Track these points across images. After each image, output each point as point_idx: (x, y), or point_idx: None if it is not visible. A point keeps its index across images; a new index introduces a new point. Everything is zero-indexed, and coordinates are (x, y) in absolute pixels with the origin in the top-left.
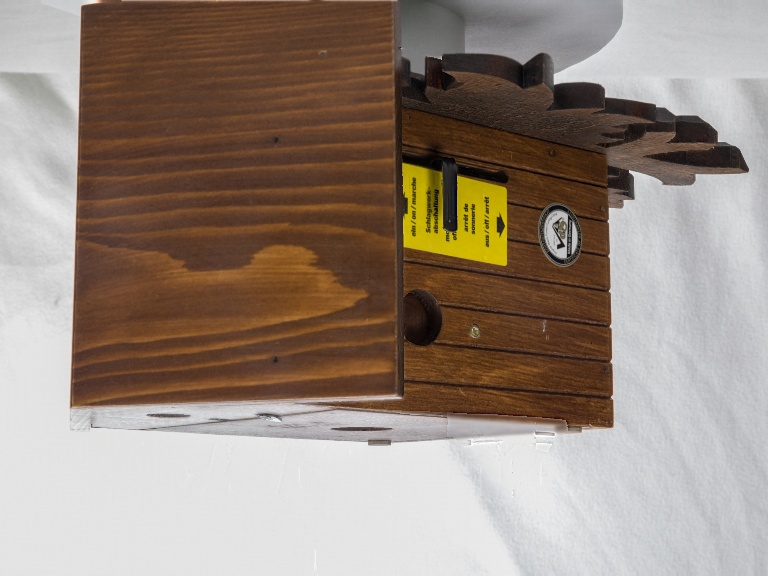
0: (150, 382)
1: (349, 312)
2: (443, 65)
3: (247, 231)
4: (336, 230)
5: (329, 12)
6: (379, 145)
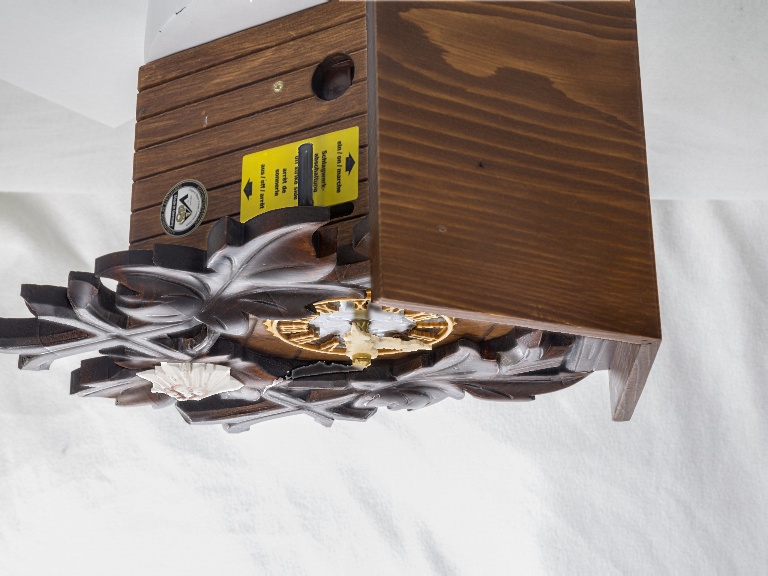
0: (573, 0)
1: (414, 5)
2: (329, 212)
3: (502, 95)
4: (427, 73)
5: (438, 265)
6: (391, 133)
